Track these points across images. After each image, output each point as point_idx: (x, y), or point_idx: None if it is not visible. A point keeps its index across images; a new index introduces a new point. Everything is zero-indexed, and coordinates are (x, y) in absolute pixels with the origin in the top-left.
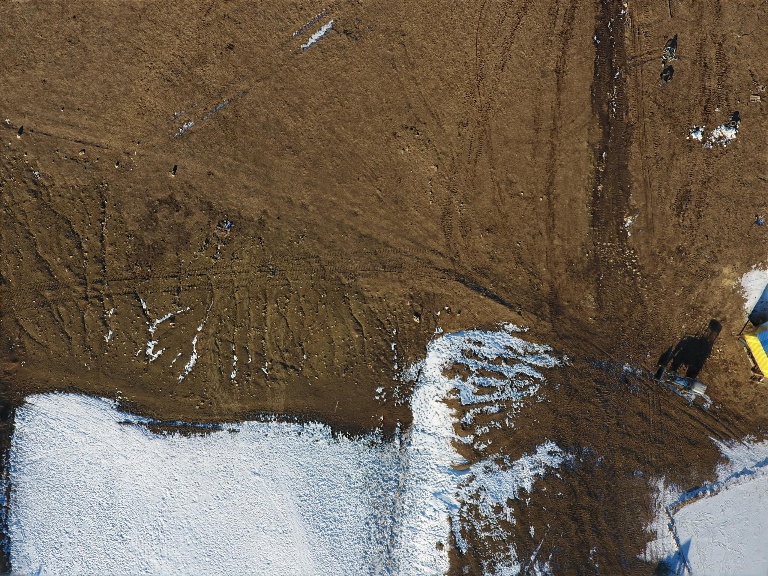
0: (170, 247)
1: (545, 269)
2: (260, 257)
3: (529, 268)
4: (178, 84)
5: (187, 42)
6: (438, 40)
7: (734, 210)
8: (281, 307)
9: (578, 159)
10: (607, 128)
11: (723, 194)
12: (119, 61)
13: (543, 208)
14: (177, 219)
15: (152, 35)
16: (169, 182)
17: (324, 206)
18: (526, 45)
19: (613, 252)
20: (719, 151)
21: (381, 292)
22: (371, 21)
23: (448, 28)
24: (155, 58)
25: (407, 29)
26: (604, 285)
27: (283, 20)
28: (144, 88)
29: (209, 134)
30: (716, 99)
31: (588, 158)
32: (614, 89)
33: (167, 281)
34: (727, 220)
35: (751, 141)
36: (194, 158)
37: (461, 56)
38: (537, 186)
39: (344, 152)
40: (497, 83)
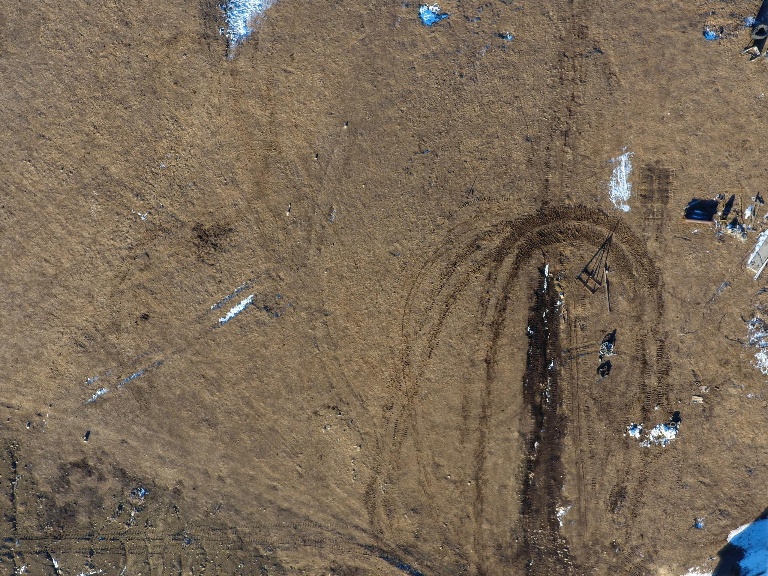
0: (82, 511)
1: (472, 551)
2: (175, 525)
3: (456, 549)
4: (91, 351)
5: (101, 309)
6: (362, 323)
7: (671, 512)
8: (196, 575)
9: (508, 447)
10: (540, 418)
11: (660, 494)
12: (30, 326)
13: (471, 492)
14: (89, 484)
15: (64, 301)
16: (81, 447)
17: (242, 479)
18: (455, 333)
19: (544, 539)
20: (657, 450)
21: (301, 564)
22: (293, 298)
23: (373, 312)
24: (68, 323)
25: (330, 309)
26: (534, 570)
27: (201, 293)
28: (56, 352)
29: (123, 403)
30: (656, 397)
31: (519, 447)
32: (548, 380)
33: (79, 543)
34: (664, 521)
35: (692, 443)
36: (107, 425)
37: (386, 340)
38: (465, 470)
39: (263, 427)
40: (423, 369)
